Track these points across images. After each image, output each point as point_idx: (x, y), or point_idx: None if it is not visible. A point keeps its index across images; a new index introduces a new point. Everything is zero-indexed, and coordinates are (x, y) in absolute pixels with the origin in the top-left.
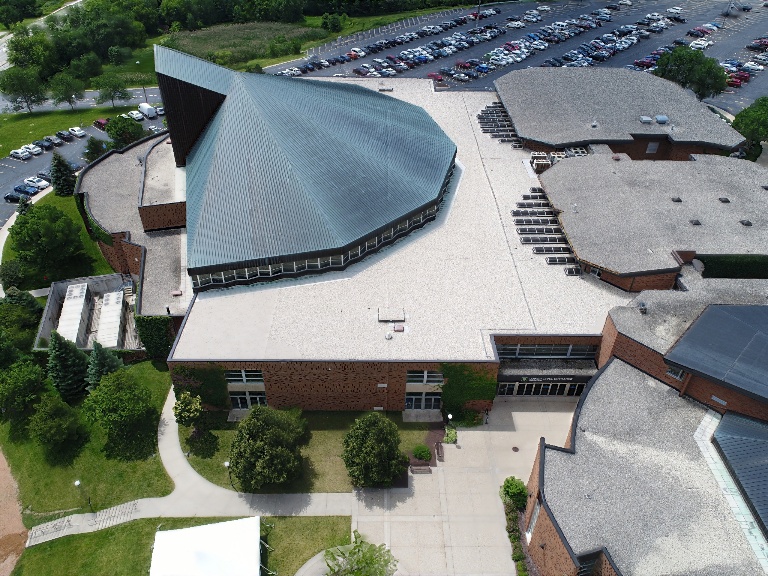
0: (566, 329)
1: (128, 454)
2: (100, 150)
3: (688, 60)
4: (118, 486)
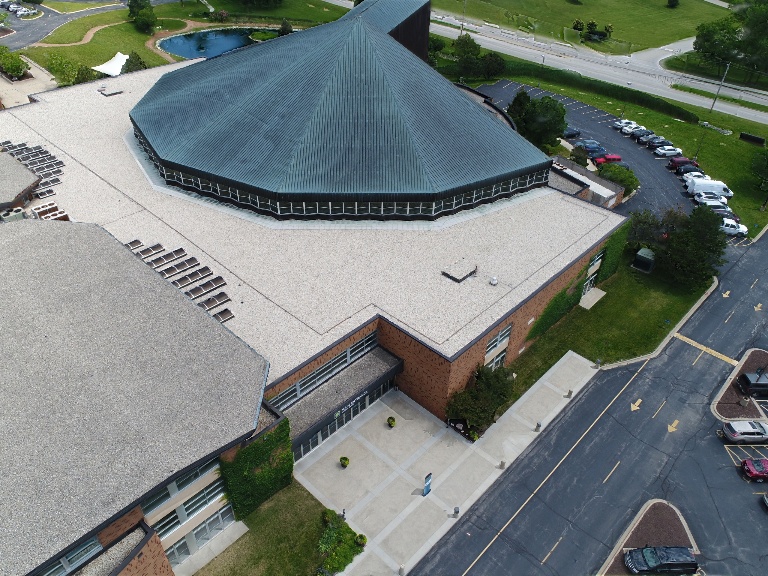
0: None
1: None
2: None
3: None
4: None
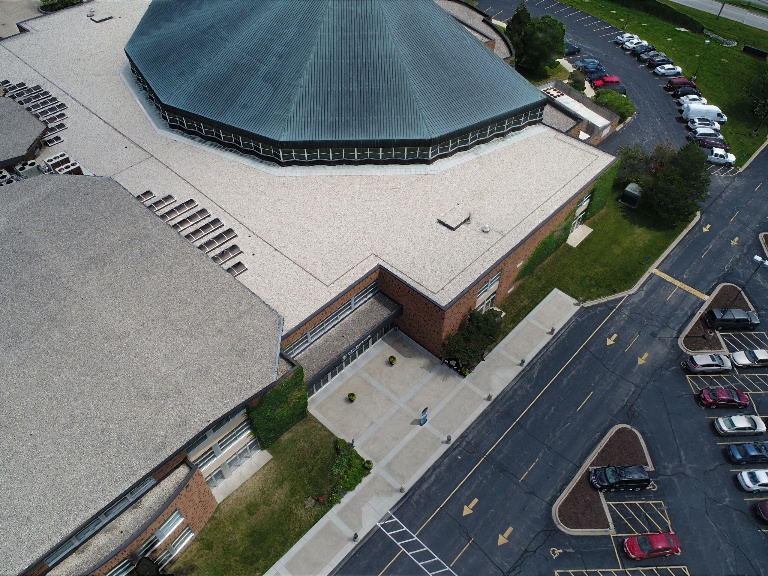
0: None
1: None
2: None
3: None
4: None
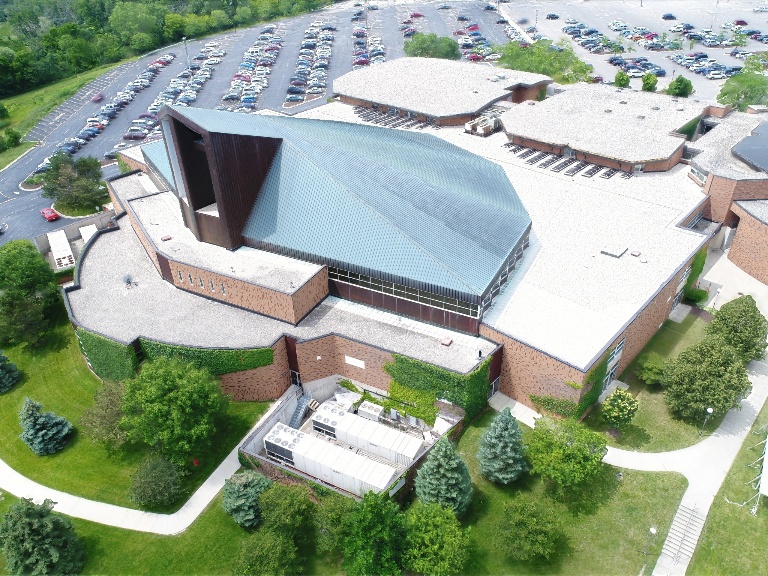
0: (691, 203)
1: (600, 494)
2: (26, 303)
3: (430, 42)
4: (646, 516)
